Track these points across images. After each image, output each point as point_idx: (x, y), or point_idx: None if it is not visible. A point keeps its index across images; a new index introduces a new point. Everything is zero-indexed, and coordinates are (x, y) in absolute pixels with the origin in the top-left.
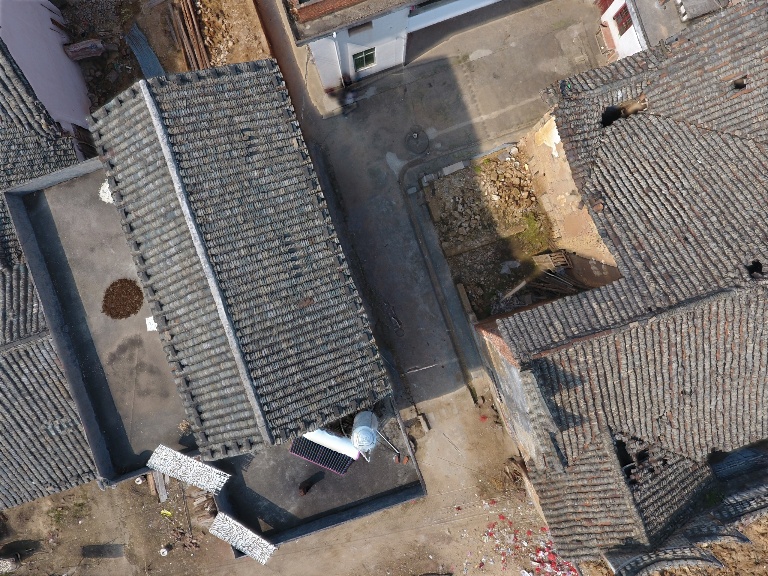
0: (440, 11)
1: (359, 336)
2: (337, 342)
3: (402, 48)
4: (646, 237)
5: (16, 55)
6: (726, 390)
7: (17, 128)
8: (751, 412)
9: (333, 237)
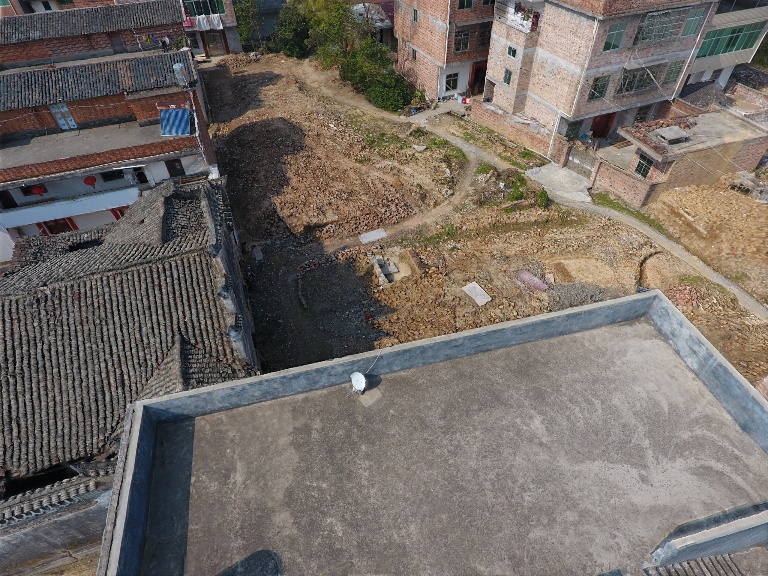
0: (22, 214)
1: None
2: None
3: (12, 242)
4: (8, 282)
5: None
6: (18, 392)
7: None
8: (50, 423)
9: None
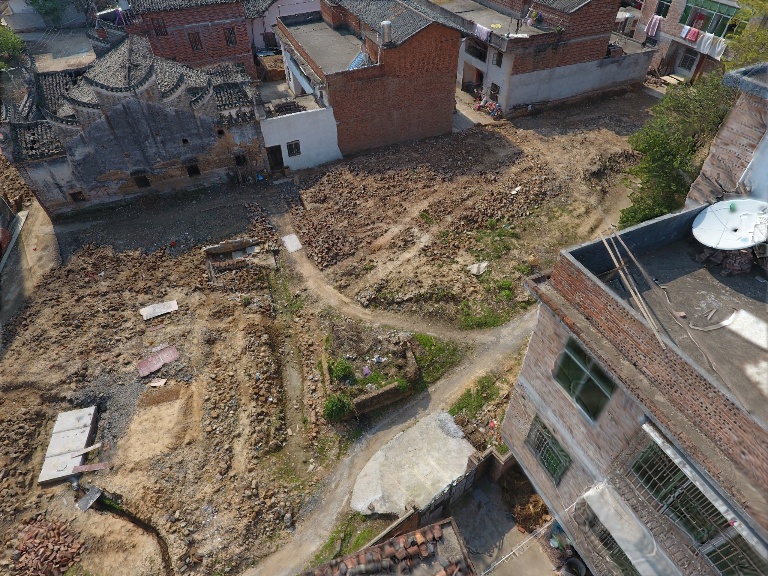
0: None
1: (155, 8)
2: (154, 4)
3: None
4: None
5: (288, 10)
6: None
7: (261, 6)
8: None
9: (189, 6)
